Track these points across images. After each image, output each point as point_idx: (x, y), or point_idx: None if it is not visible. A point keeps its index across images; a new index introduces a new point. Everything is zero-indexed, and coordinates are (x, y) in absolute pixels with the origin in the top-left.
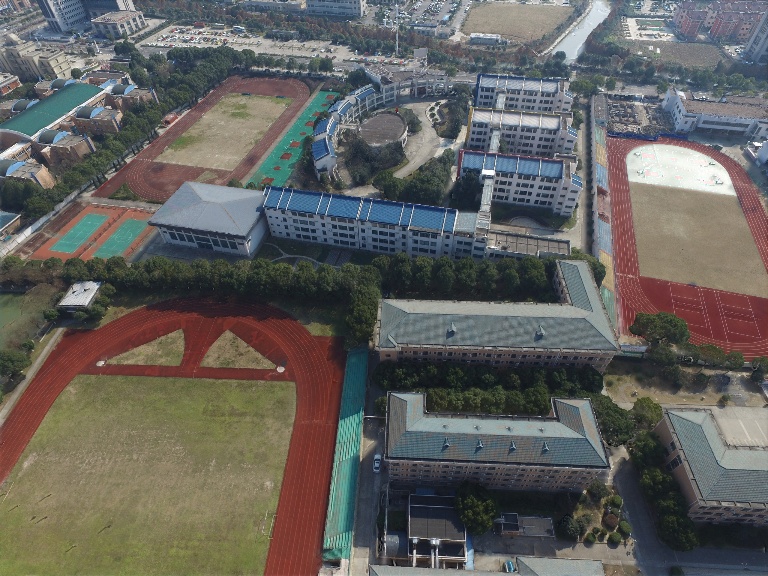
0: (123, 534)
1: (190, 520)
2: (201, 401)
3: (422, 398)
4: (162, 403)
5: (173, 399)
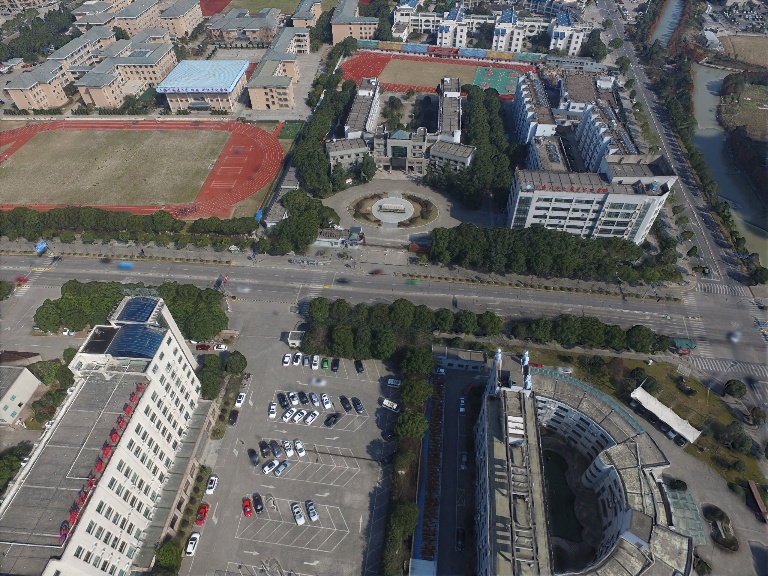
0: None
1: None
2: None
3: (318, 2)
4: None
5: None
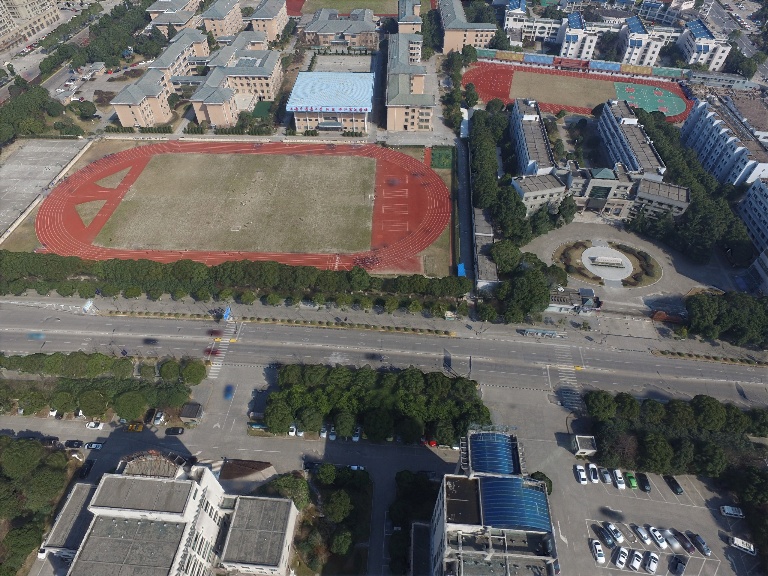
0: (382, 1)
1: (386, 6)
2: (422, 4)
3: (419, 4)
4: (421, 0)
5: (422, 1)
